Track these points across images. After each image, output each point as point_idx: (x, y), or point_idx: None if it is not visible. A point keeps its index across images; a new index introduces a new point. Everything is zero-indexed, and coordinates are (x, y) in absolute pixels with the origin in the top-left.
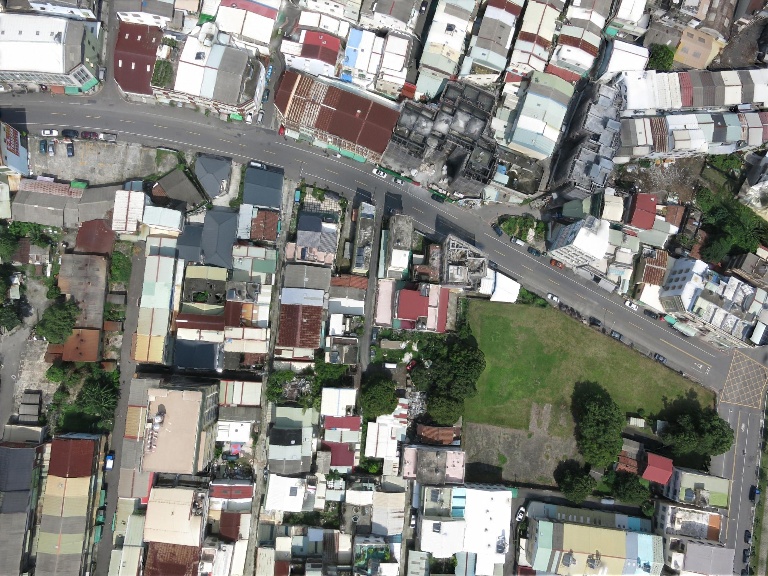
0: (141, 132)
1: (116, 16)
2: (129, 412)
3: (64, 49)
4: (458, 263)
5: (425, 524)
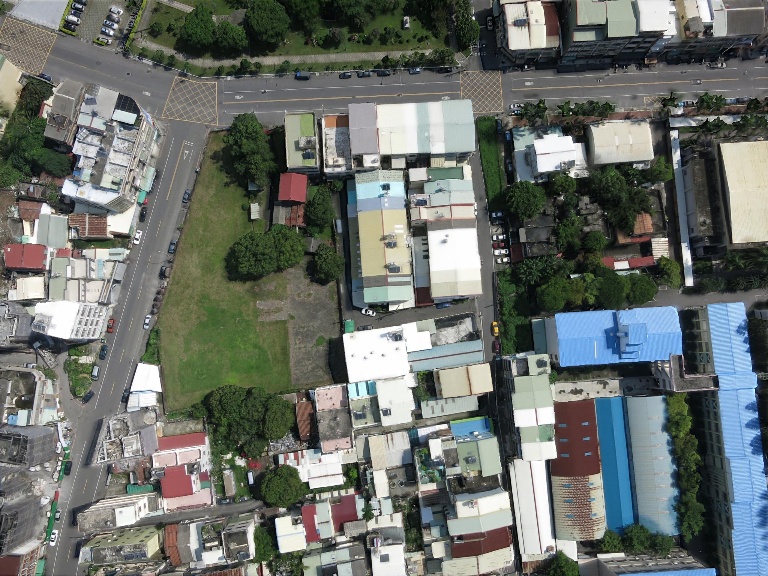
0: None
1: None
2: None
3: None
4: None
5: (386, 424)
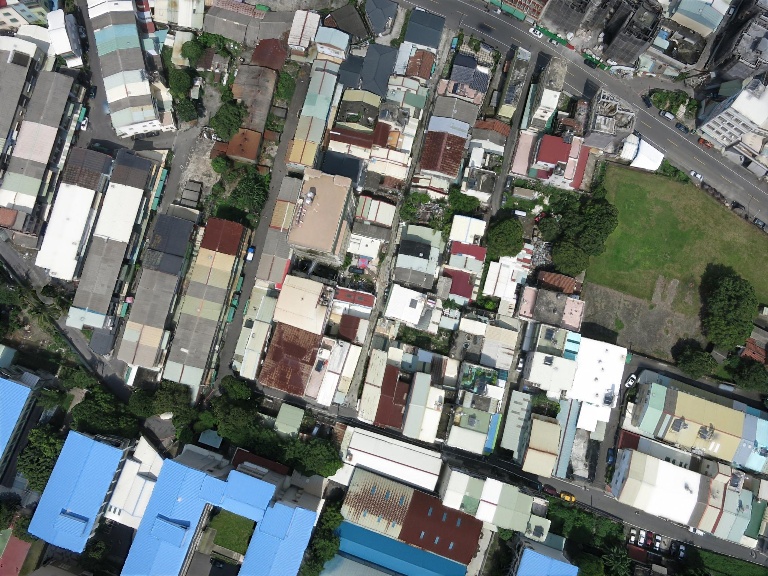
0: None
1: None
2: (277, 205)
3: None
4: (606, 116)
5: (537, 356)
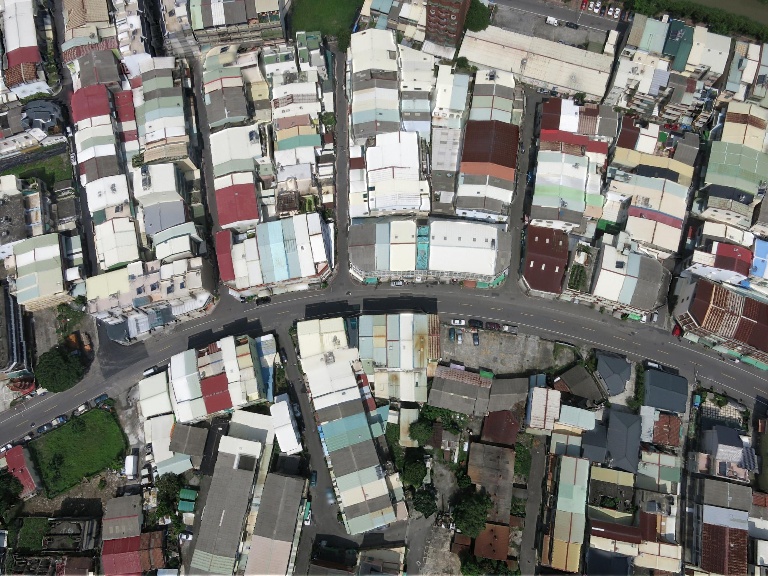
0: (540, 325)
1: (526, 220)
2: None
3: (497, 254)
4: None
5: None
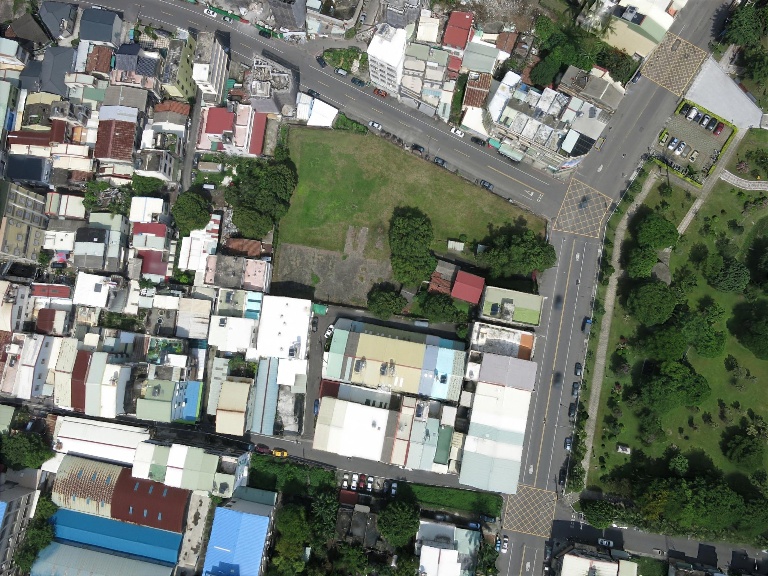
0: None
1: None
2: None
3: None
4: None
5: (213, 319)
